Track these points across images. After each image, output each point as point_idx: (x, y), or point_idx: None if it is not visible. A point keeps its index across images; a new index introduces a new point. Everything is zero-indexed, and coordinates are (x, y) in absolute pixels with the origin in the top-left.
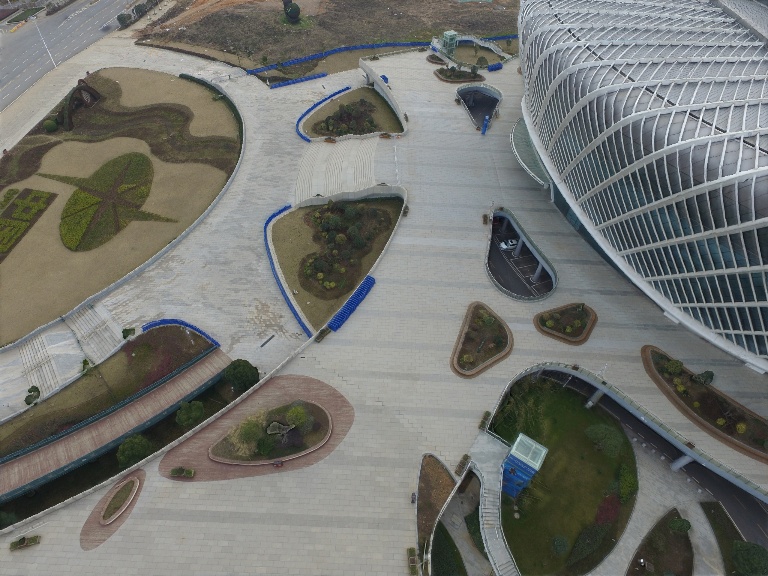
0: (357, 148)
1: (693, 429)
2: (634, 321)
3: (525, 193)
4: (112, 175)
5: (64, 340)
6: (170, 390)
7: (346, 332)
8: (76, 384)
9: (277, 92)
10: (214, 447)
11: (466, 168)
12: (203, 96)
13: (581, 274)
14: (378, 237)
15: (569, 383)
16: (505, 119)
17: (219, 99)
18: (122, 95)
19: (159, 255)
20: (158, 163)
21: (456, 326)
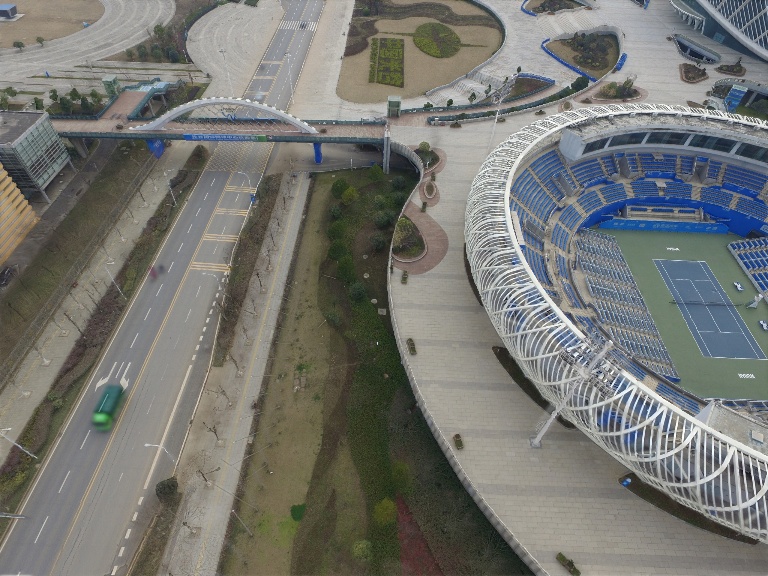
0: (572, 15)
1: None
2: (765, 71)
3: (684, 31)
4: (428, 31)
5: (473, 83)
6: (546, 93)
7: (624, 71)
8: None
9: None
10: (594, 96)
11: (644, 21)
12: None
13: (731, 57)
14: (609, 49)
15: None
16: (654, 3)
17: None
18: None
19: (495, 55)
20: (451, 26)
21: (677, 70)
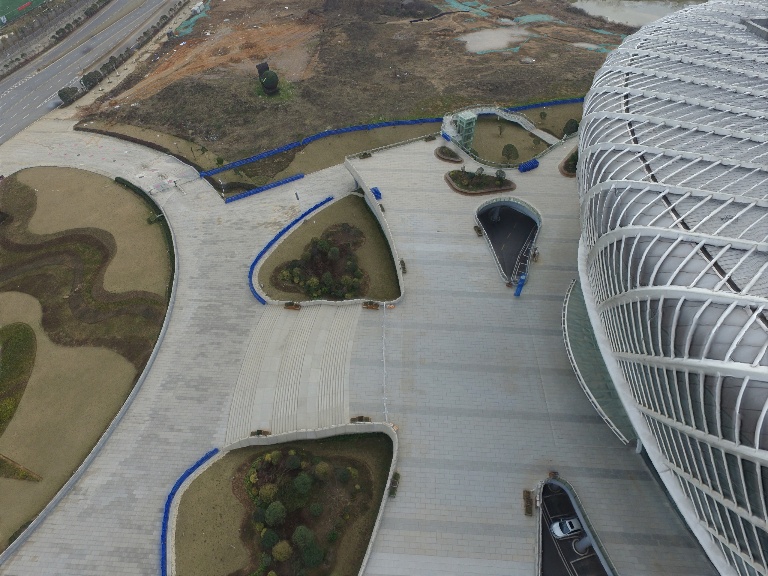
0: (329, 325)
1: None
2: None
3: (590, 430)
4: None
5: None
6: None
7: None
8: None
9: (233, 209)
10: None
11: (493, 372)
12: (136, 215)
13: None
14: (348, 531)
15: None
16: (548, 263)
17: (155, 221)
18: (35, 213)
19: None
20: (45, 346)
21: None
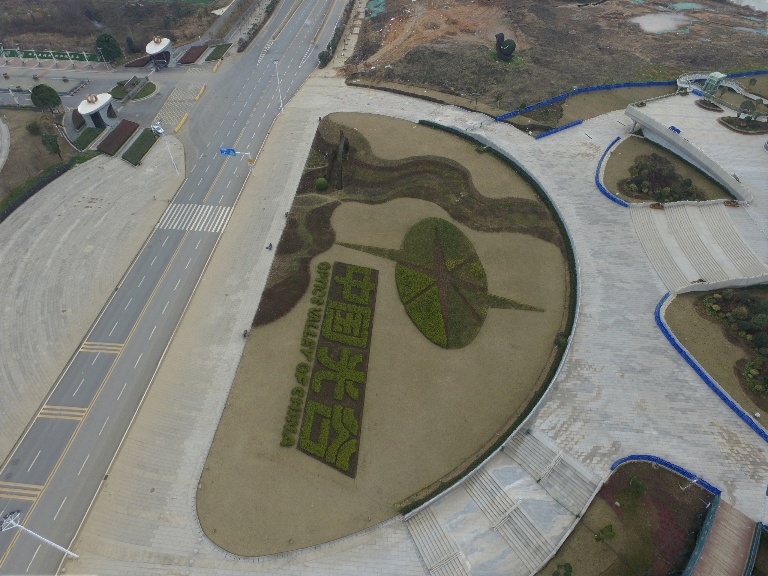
0: (702, 218)
1: None
2: None
3: None
4: (426, 247)
5: (517, 478)
6: (711, 565)
7: None
8: (570, 545)
9: (545, 143)
10: None
11: None
12: (463, 147)
13: None
14: None
15: None
16: None
17: (485, 151)
18: (371, 145)
19: (564, 360)
20: (469, 232)
21: None
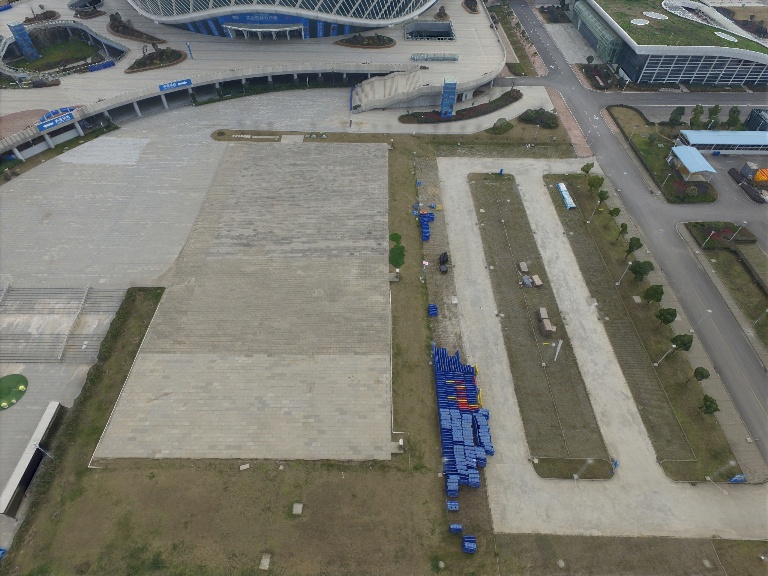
0: None
1: (106, 33)
2: None
3: None
4: None
5: None
6: None
7: None
8: None
9: None
10: None
11: None
12: None
13: (116, 5)
14: None
15: (85, 38)
16: None
17: None
18: None
19: None
20: None
21: None
